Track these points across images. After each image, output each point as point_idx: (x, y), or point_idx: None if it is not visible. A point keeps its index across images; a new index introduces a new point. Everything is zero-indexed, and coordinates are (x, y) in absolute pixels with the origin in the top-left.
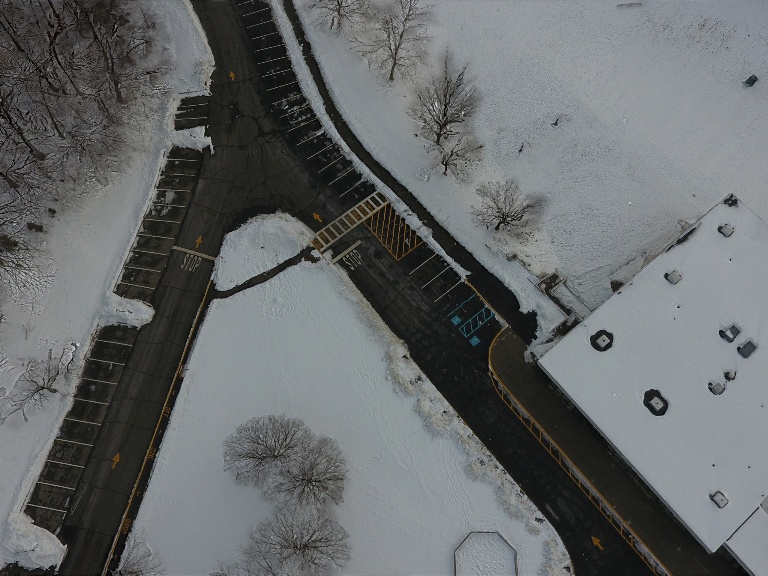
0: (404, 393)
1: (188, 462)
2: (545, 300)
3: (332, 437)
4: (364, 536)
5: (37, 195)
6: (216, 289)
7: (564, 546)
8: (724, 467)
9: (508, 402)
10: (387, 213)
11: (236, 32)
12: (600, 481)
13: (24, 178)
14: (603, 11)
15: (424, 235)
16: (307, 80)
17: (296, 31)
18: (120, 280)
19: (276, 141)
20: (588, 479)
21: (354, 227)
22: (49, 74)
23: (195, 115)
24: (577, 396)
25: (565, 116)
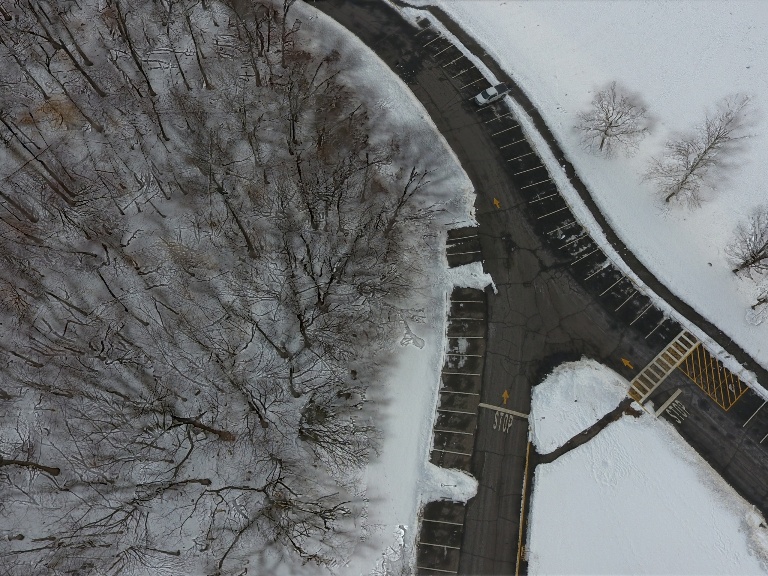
0: None
1: None
2: None
3: None
4: None
5: (347, 360)
6: (537, 452)
7: None
8: None
9: None
10: (701, 355)
11: (489, 154)
12: None
13: (317, 336)
14: None
15: (748, 380)
16: (579, 206)
17: (554, 151)
18: (432, 446)
19: (561, 276)
20: None
21: (669, 373)
22: (319, 215)
23: (467, 249)
24: None
25: None
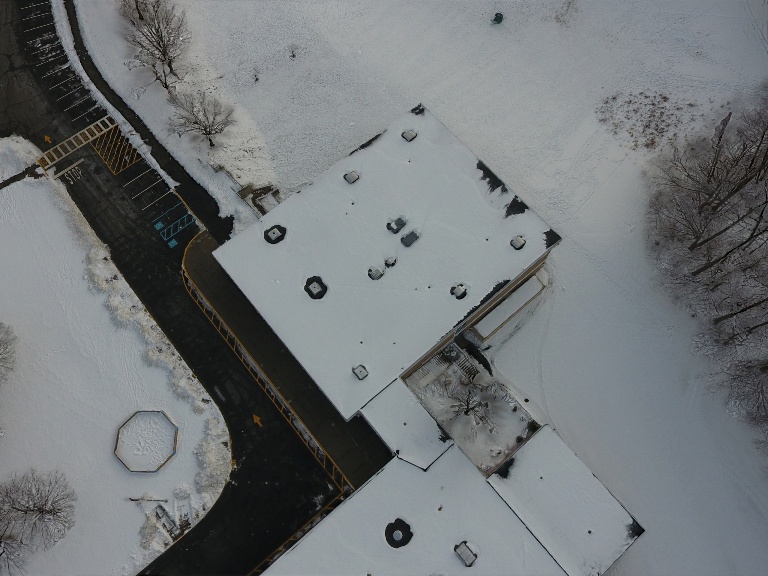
0: (97, 290)
1: None
2: (243, 206)
3: (22, 330)
4: (36, 416)
5: None
6: None
7: (225, 424)
8: (370, 344)
9: (195, 297)
10: (113, 134)
11: None
12: (268, 365)
13: None
14: None
15: (143, 152)
16: (62, 21)
17: None
18: None
19: (24, 75)
20: (257, 363)
21: (80, 147)
22: None
23: None
24: (242, 283)
25: (304, 49)
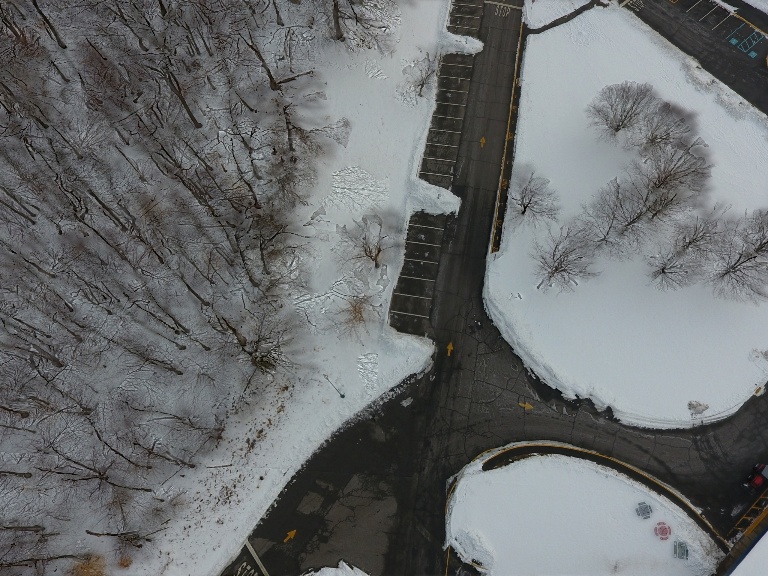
0: (705, 90)
1: (542, 141)
2: None
3: None
4: None
5: None
6: (529, 28)
7: None
8: None
9: None
10: None
11: None
12: None
13: None
14: None
15: None
16: None
17: None
18: (449, 24)
19: None
20: None
21: None
22: None
23: None
24: None
25: None
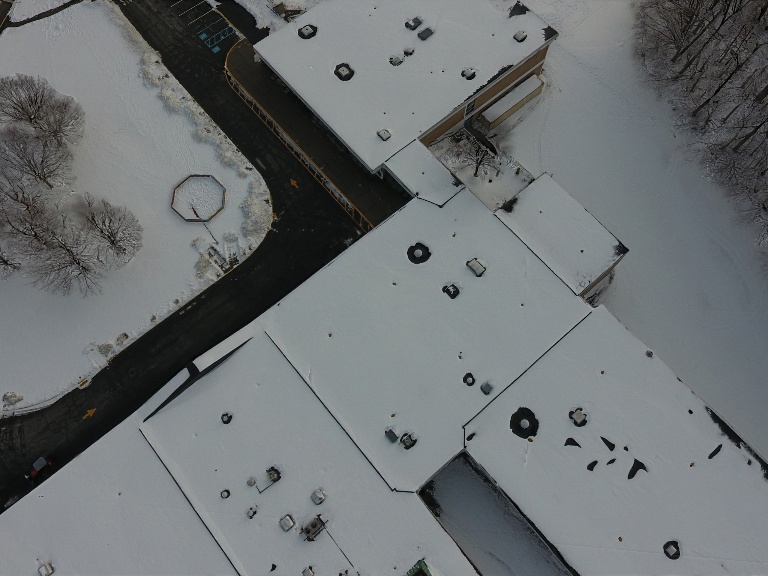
0: (151, 84)
1: None
2: (278, 19)
3: (87, 115)
4: (102, 180)
5: None
6: (10, 21)
7: (266, 186)
8: (392, 114)
9: (237, 90)
10: None
11: None
12: (303, 141)
13: None
14: None
15: None
16: None
17: None
18: None
19: None
20: (293, 140)
21: None
22: None
23: None
24: (280, 68)
25: None
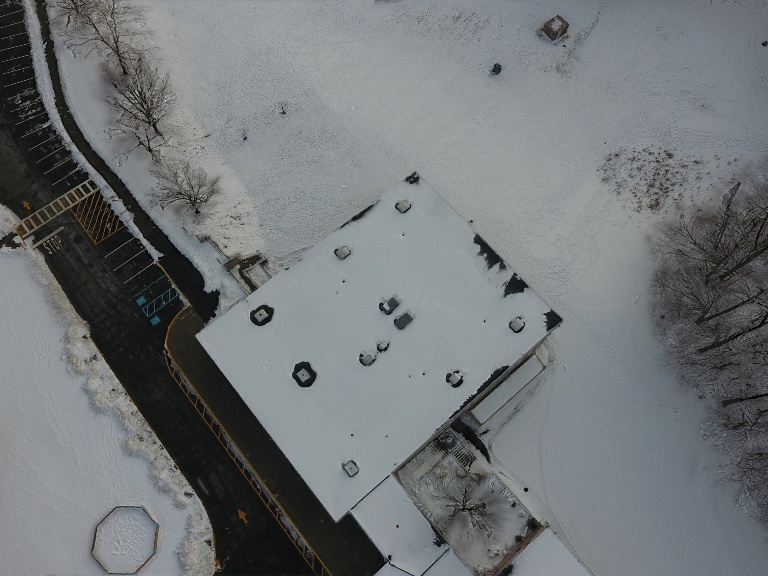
0: (75, 372)
1: None
2: (230, 279)
3: None
4: (9, 512)
5: None
6: None
7: (209, 520)
8: (361, 437)
9: (178, 379)
10: (95, 200)
11: None
12: (255, 455)
13: None
14: (361, 7)
15: (126, 220)
16: (43, 76)
17: (43, 31)
18: None
19: (2, 134)
20: (243, 453)
21: (60, 214)
22: None
23: None
24: (227, 369)
25: (294, 105)
